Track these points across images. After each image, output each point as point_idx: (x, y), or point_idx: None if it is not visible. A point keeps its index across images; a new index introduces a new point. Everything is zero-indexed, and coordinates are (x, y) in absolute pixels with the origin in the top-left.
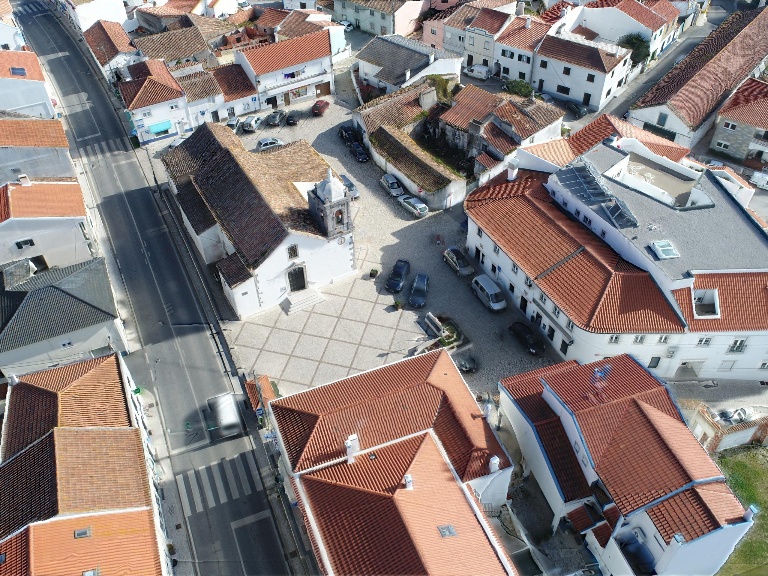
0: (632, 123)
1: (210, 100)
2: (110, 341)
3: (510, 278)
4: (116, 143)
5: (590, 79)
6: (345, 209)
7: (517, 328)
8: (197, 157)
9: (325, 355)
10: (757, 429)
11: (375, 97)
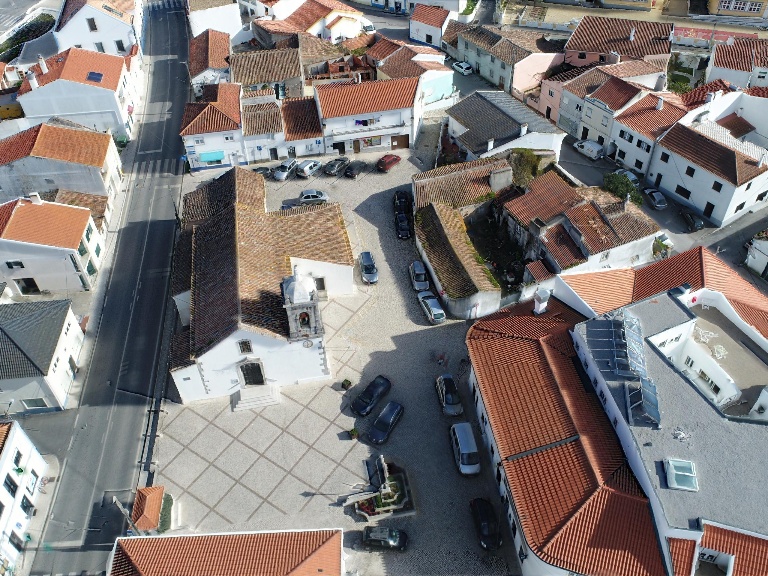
0: (754, 254)
1: (269, 136)
2: (42, 394)
3: (492, 439)
4: (170, 164)
5: (716, 187)
6: (312, 312)
7: (476, 508)
8: (213, 204)
9: (246, 474)
10: None
11: (450, 162)
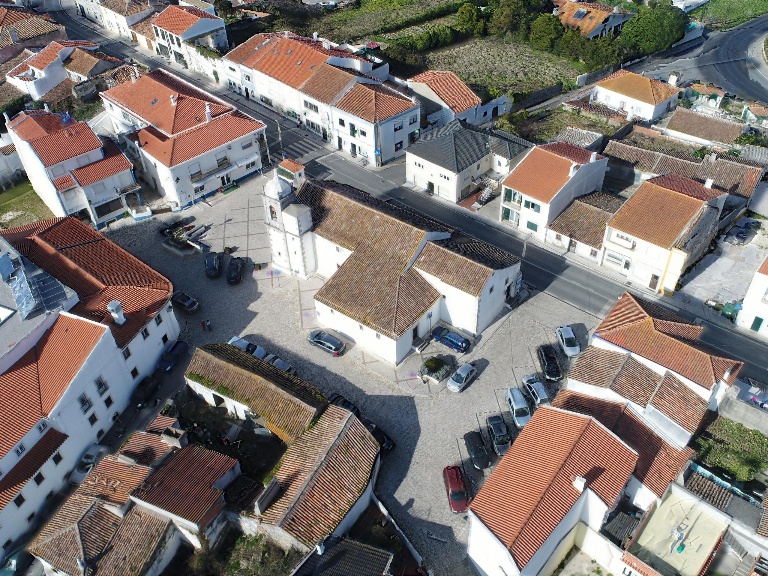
0: None
1: None
2: None
3: None
4: None
5: None
6: None
7: None
8: (470, 251)
9: None
10: None
11: None
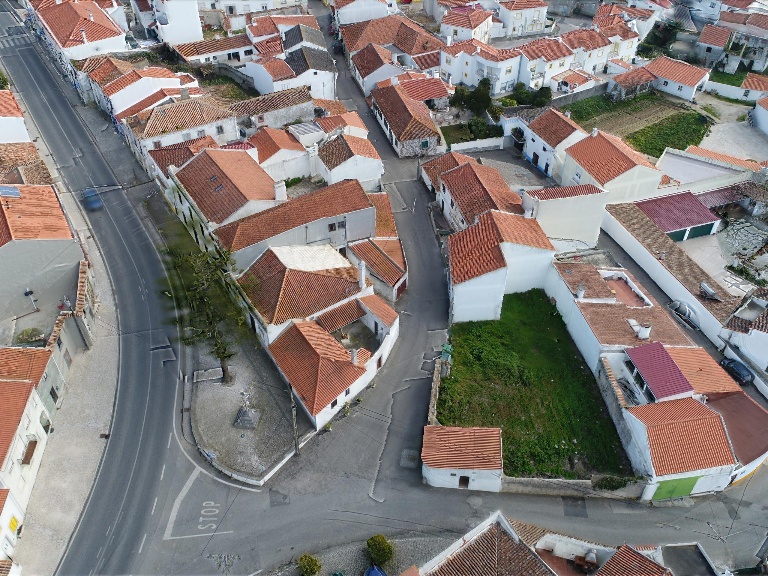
0: None
1: None
2: None
3: None
4: None
5: None
6: None
7: None
8: None
9: None
10: (247, 19)
11: None
